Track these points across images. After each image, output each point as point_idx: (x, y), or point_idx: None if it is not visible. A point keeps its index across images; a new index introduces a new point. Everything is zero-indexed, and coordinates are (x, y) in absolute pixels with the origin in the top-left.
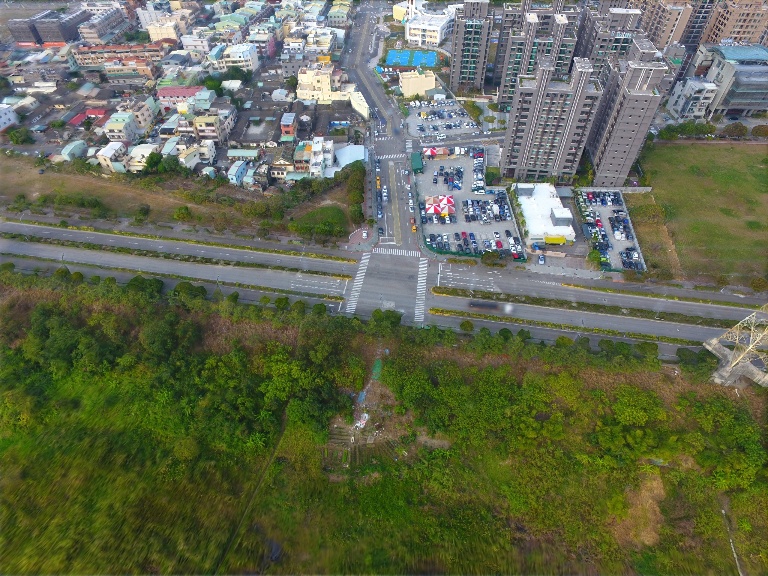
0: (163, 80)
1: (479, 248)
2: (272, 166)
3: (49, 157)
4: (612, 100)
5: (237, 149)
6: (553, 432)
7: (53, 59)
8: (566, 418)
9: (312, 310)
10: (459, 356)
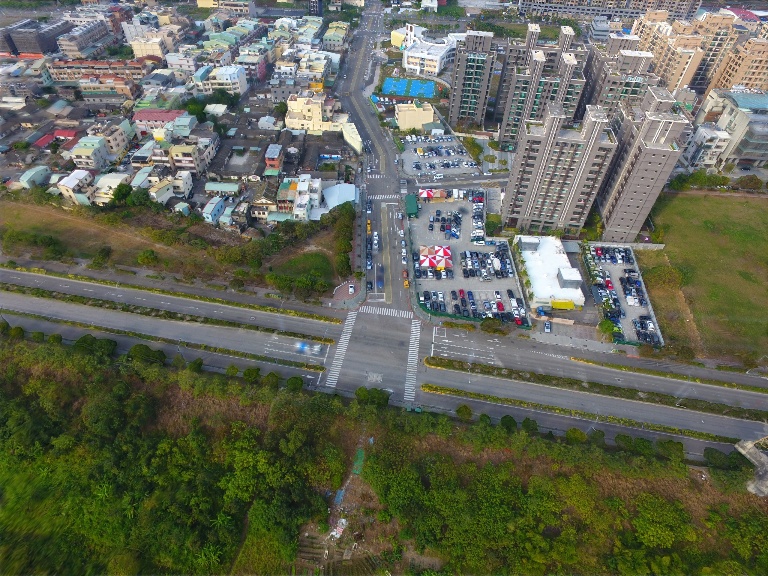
0: (142, 101)
1: (478, 310)
2: (253, 205)
3: (6, 183)
4: (625, 150)
5: (216, 182)
6: (564, 554)
7: (25, 73)
8: (578, 532)
9: (286, 385)
10: (454, 448)
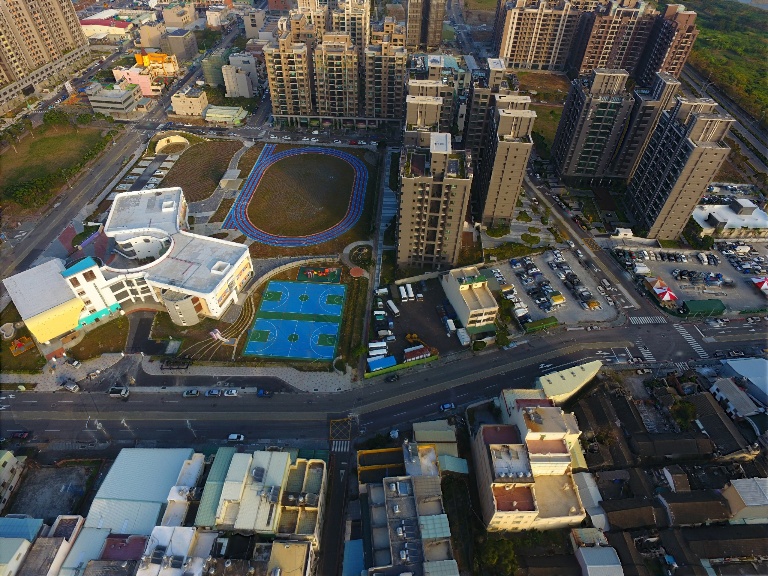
0: None
1: None
2: None
3: None
4: (641, 122)
5: None
6: None
7: None
8: None
9: None
10: None
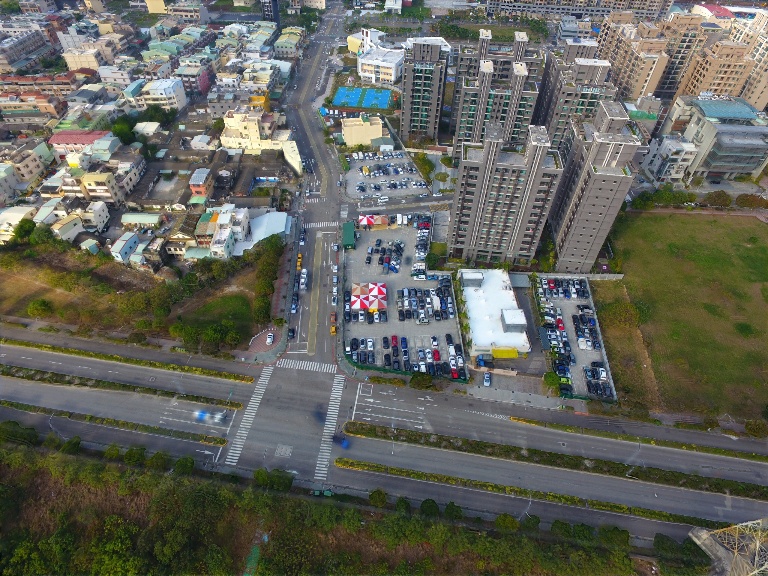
0: (63, 121)
1: (411, 360)
2: (168, 240)
3: None
4: (576, 173)
5: (135, 213)
6: None
7: None
8: None
9: None
10: (366, 542)
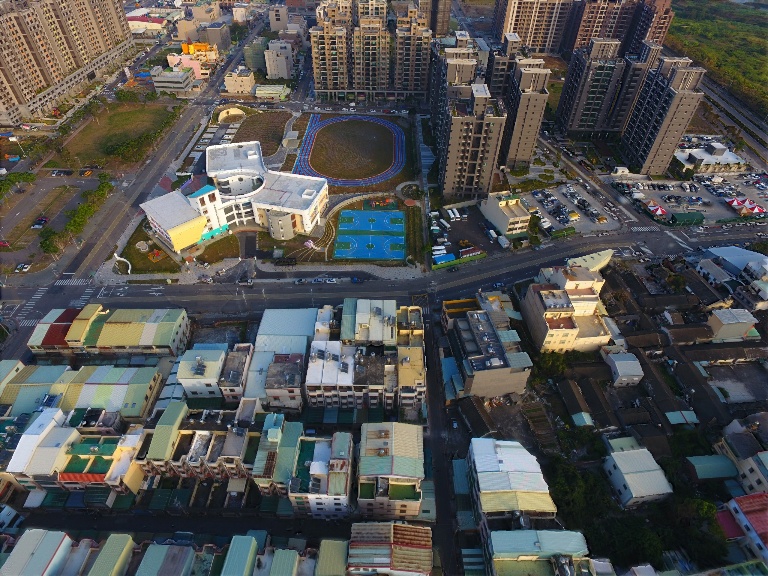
0: None
1: None
2: None
3: None
4: (632, 82)
5: None
6: None
7: None
8: None
9: None
10: None
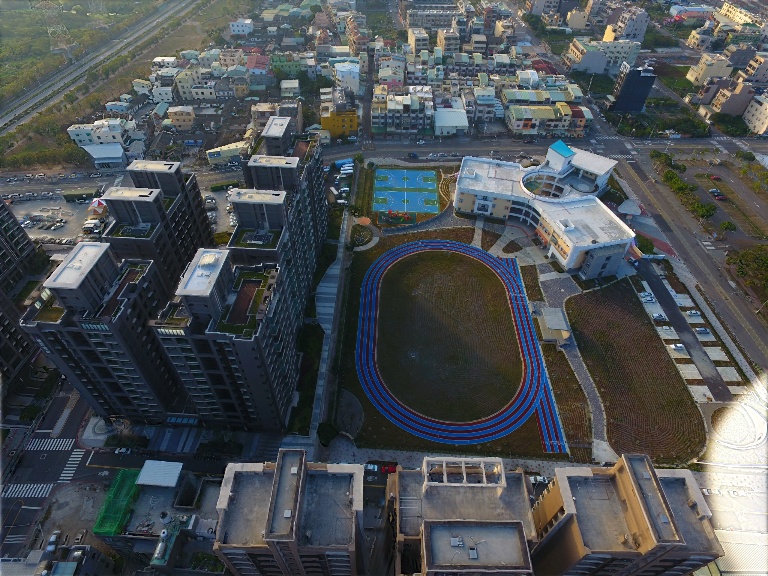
0: None
1: None
2: None
3: None
4: None
5: (165, 105)
6: None
7: None
8: None
9: None
10: None
